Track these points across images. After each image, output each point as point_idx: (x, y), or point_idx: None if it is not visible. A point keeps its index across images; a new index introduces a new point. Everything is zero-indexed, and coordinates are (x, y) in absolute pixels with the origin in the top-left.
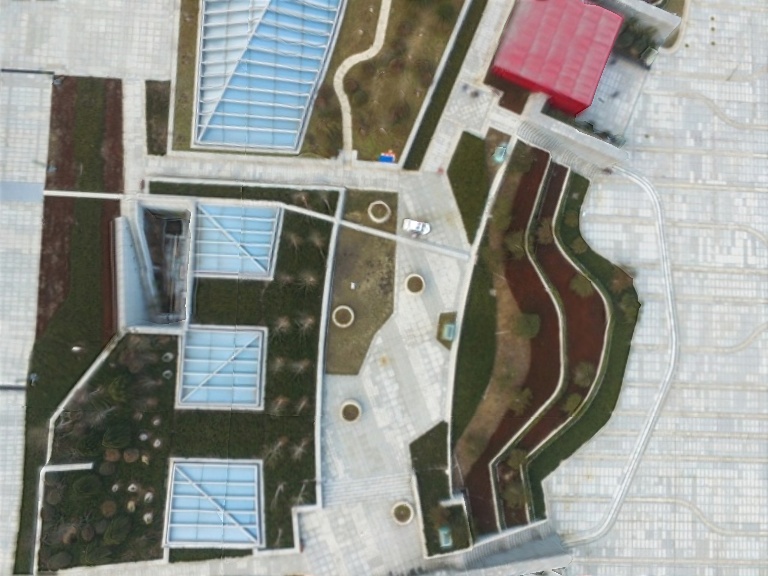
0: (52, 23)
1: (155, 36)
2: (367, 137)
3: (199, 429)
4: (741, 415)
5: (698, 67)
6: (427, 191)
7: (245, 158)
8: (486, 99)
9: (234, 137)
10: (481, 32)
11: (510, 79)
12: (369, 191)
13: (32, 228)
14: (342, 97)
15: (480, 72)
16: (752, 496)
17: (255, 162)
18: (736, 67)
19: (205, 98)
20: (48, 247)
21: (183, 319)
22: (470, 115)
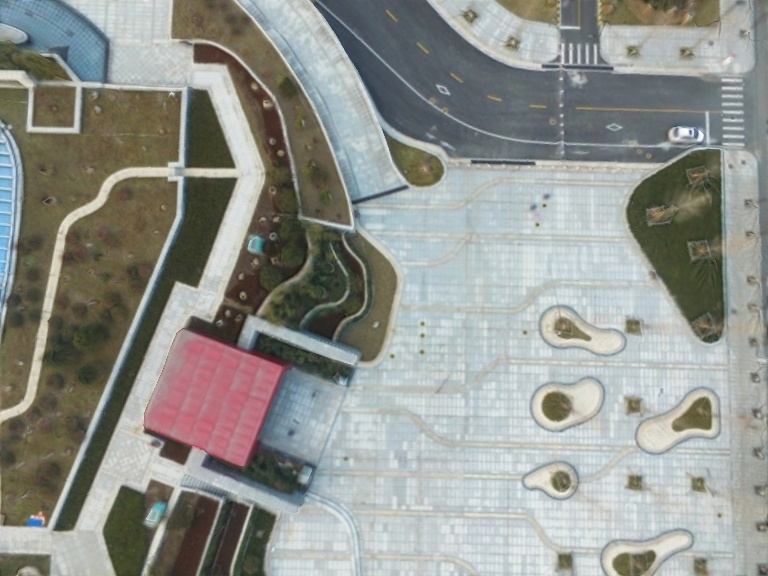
0: None
1: None
2: (11, 504)
3: None
4: None
5: (404, 379)
6: (82, 552)
7: None
8: (147, 449)
9: None
10: (142, 377)
11: (164, 436)
12: (20, 554)
13: None
14: None
15: (141, 420)
16: None
17: None
18: (447, 377)
19: None
20: None
21: None
22: (130, 467)
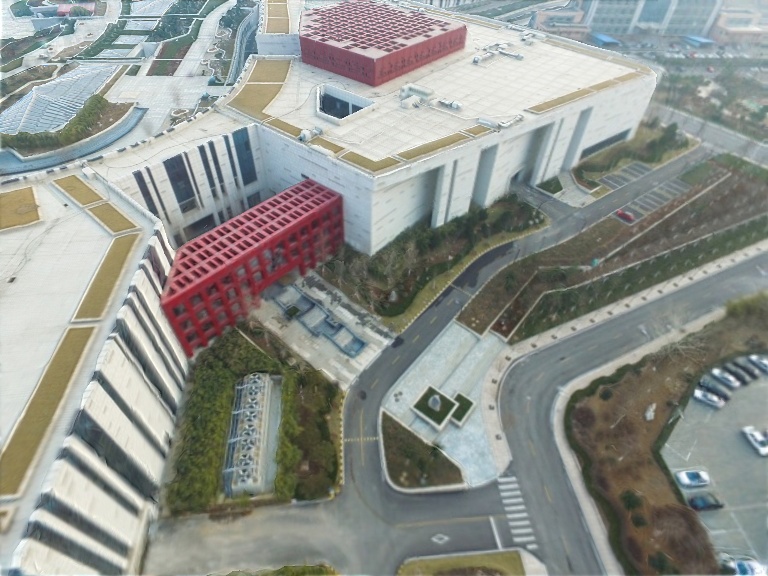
0: None
1: None
2: None
3: None
4: None
5: None
6: None
7: None
8: None
9: None
10: None
11: None
12: None
13: None
14: (55, 74)
15: None
16: None
17: None
18: None
19: None
20: None
21: None
22: None
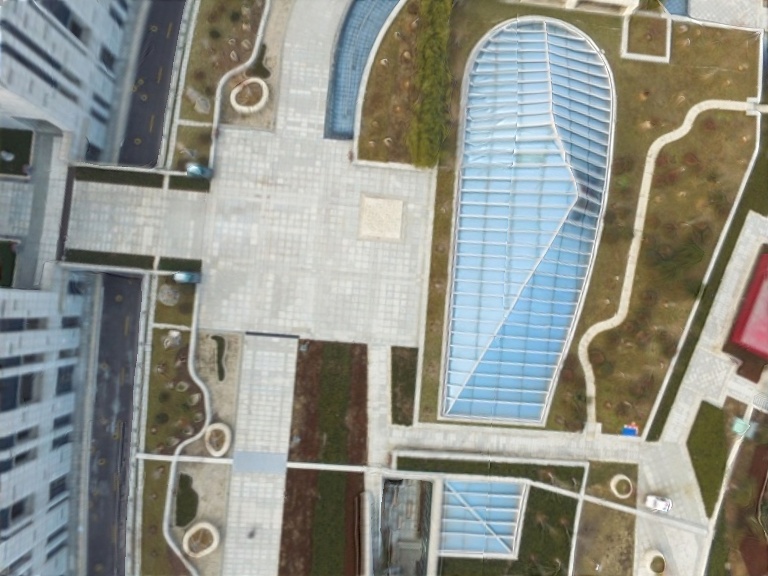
0: (298, 284)
1: (401, 299)
2: (614, 412)
3: None
4: None
5: None
6: (666, 462)
7: (491, 430)
8: (724, 367)
9: (481, 409)
10: (720, 298)
11: (754, 353)
12: (610, 463)
13: (273, 501)
14: (587, 367)
15: (718, 339)
16: None
17: (499, 433)
18: None
19: (453, 368)
20: (289, 522)
21: (400, 572)
22: (708, 383)
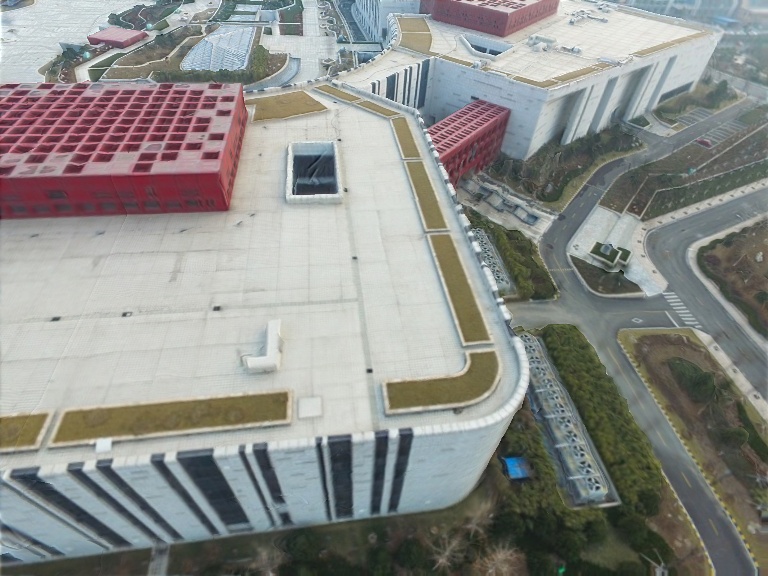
0: (305, 41)
1: None
2: None
3: (255, 2)
4: (81, 11)
5: None
6: None
7: None
8: (150, 34)
9: None
10: None
11: None
12: (198, 24)
13: None
14: (204, 32)
15: (150, 37)
16: (86, 4)
17: None
18: None
19: None
20: None
21: None
22: None
